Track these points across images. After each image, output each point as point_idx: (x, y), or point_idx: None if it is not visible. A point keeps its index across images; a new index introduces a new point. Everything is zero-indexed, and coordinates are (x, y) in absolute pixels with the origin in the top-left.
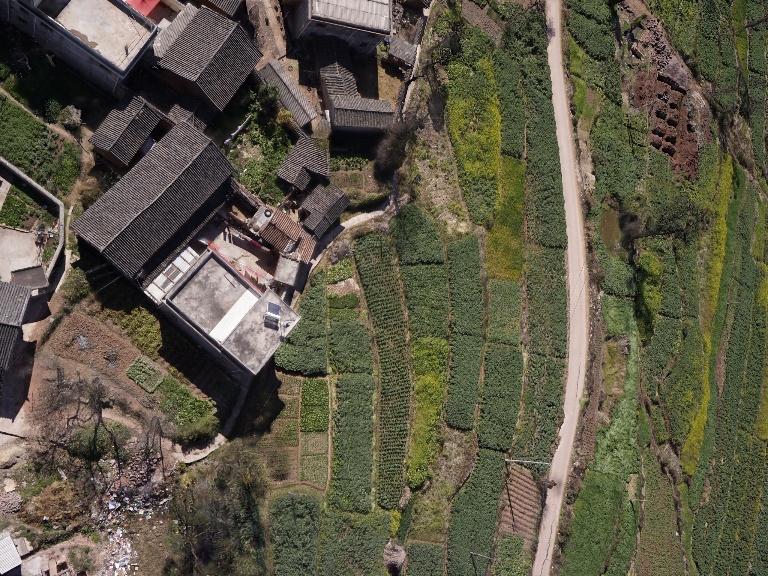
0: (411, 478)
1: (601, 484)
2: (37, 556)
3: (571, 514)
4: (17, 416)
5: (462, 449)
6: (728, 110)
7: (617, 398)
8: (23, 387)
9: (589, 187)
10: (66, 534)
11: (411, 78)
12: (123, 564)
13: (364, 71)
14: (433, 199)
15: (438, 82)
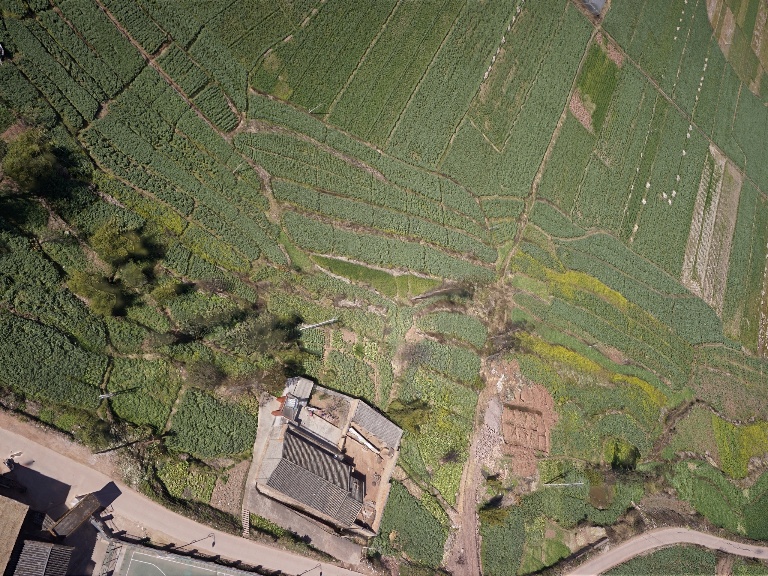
0: None
1: None
2: None
3: None
4: None
5: None
6: None
7: (666, 482)
8: None
9: None
10: None
11: None
12: None
13: None
14: None
15: None
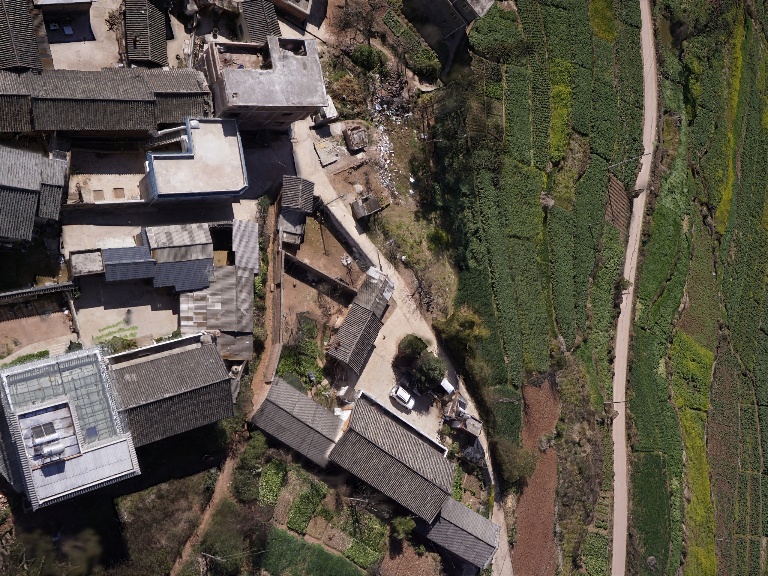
0: (553, 154)
1: (666, 214)
2: (339, 122)
3: (650, 222)
4: (321, 27)
5: (581, 149)
6: None
7: (673, 157)
8: (323, 8)
9: None
10: (353, 115)
11: None
12: (385, 149)
13: None
14: None
15: None
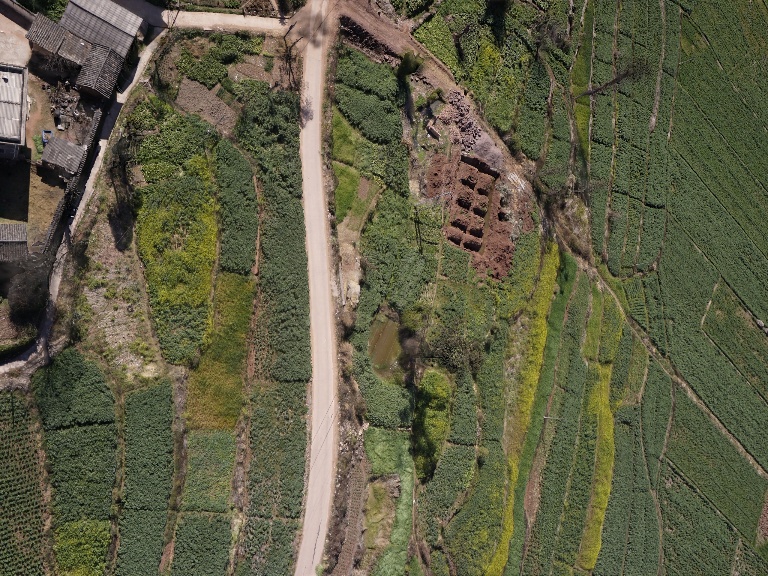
0: None
1: None
2: None
3: None
4: None
5: None
6: (553, 193)
7: (380, 552)
8: None
9: (351, 301)
10: None
11: (89, 184)
12: None
13: (8, 181)
14: (108, 338)
15: (130, 186)
